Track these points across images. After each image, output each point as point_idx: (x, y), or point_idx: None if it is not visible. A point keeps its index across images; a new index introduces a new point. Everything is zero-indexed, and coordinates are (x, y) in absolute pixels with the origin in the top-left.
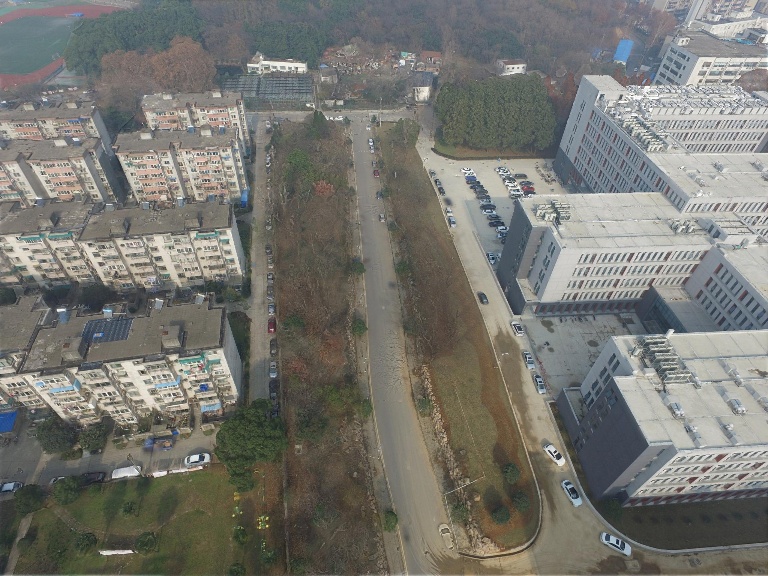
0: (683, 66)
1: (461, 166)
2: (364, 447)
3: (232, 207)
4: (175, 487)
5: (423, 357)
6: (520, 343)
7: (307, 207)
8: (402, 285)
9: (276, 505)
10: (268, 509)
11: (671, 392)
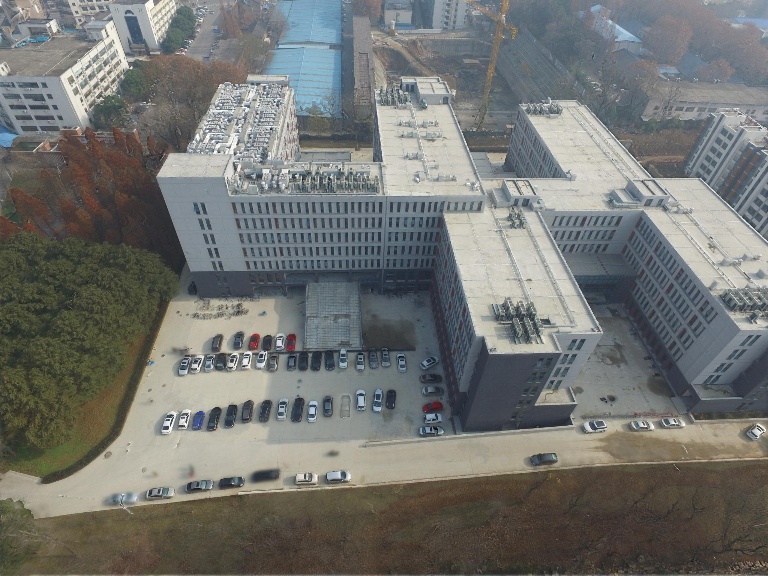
0: (46, 95)
1: (144, 431)
2: None
3: None
4: None
5: (718, 569)
6: (614, 429)
7: None
8: None
9: None
10: None
11: None
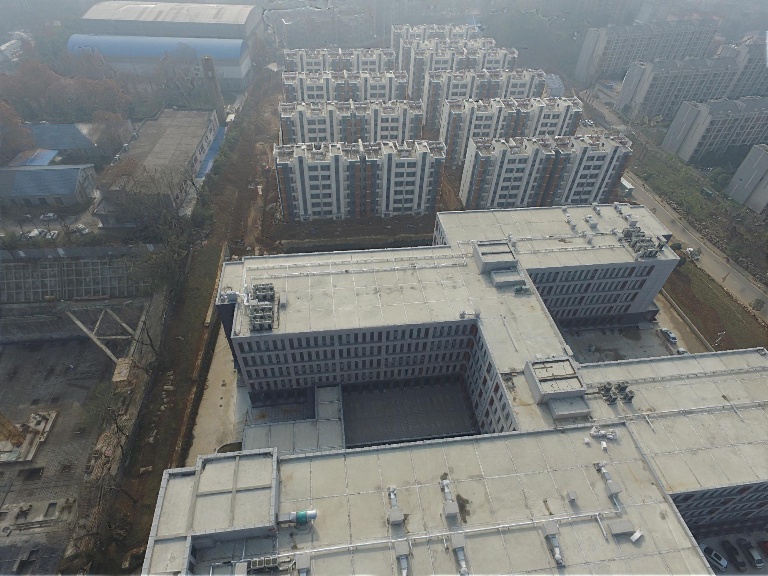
0: None
1: None
2: None
3: None
4: None
5: None
6: None
7: None
8: None
9: None
10: None
11: None
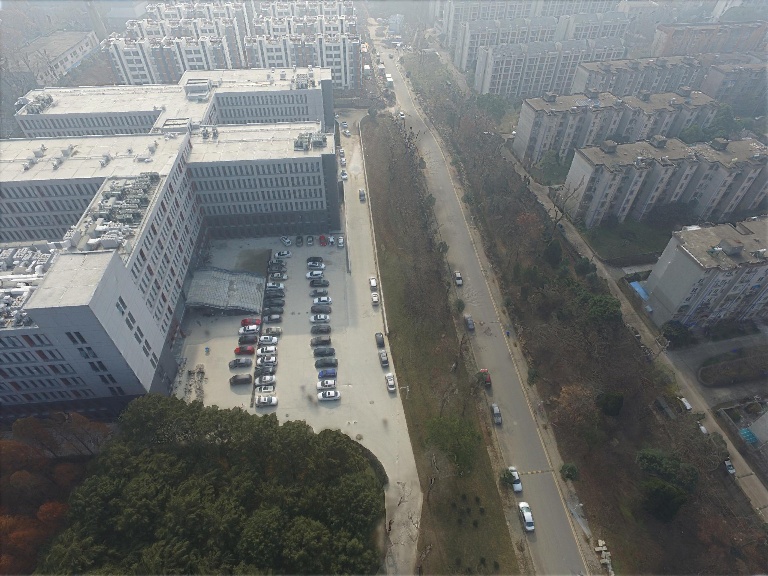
0: None
1: (336, 415)
2: None
3: (591, 163)
4: None
5: None
6: None
7: None
8: None
9: None
10: None
11: None
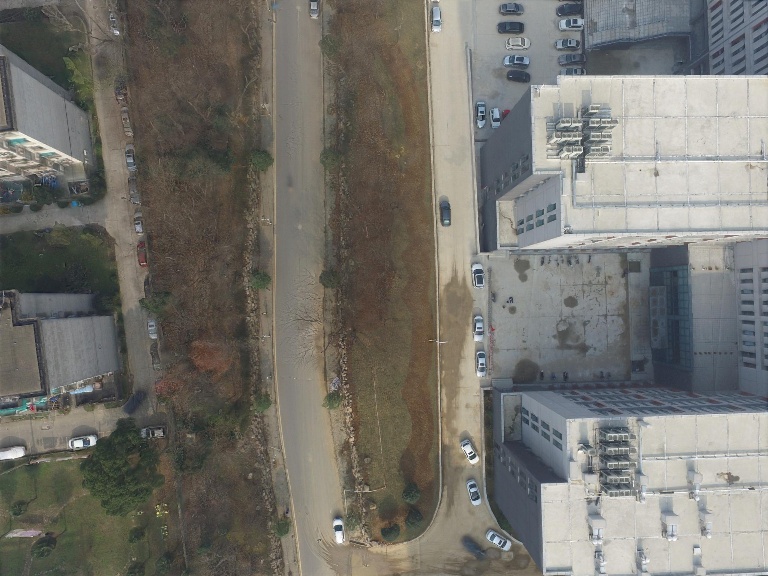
0: None
1: None
2: (263, 439)
3: (5, 68)
4: (66, 470)
5: None
6: (475, 298)
7: (167, 7)
8: (331, 182)
9: (173, 492)
10: (166, 494)
11: (604, 504)
